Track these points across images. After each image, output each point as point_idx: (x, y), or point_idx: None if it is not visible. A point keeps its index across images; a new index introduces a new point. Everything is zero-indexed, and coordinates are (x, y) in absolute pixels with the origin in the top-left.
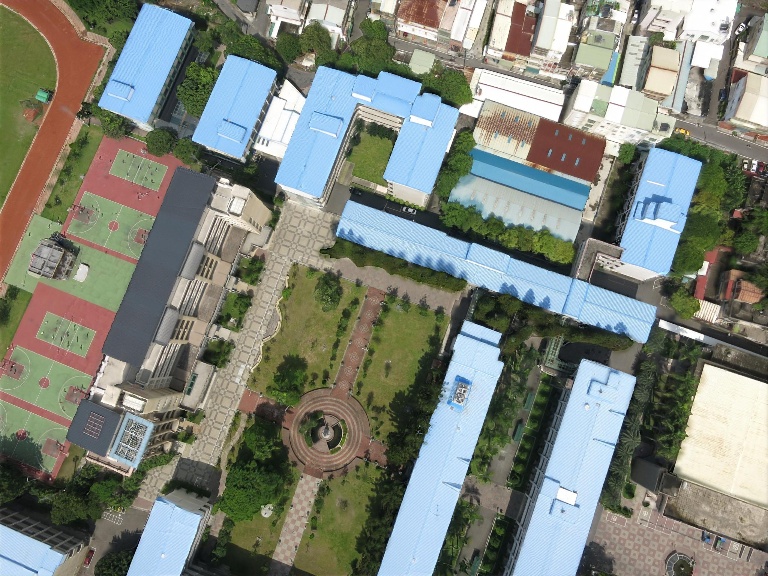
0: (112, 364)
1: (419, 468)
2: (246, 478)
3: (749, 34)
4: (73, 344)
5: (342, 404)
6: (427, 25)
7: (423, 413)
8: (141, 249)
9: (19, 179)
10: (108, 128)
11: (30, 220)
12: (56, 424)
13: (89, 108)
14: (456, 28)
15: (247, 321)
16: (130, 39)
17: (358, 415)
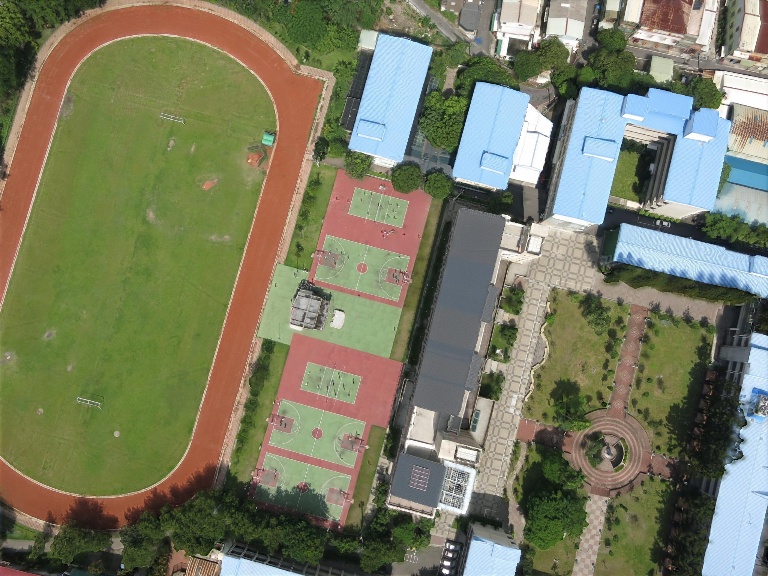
0: (420, 415)
1: (727, 481)
2: (556, 508)
3: None
4: (340, 392)
5: (619, 423)
6: (673, 32)
7: (733, 429)
8: (394, 289)
9: (255, 229)
10: (356, 169)
11: (274, 270)
12: (336, 473)
13: (324, 148)
14: (701, 32)
15: (513, 351)
16: (372, 74)
17: (636, 432)
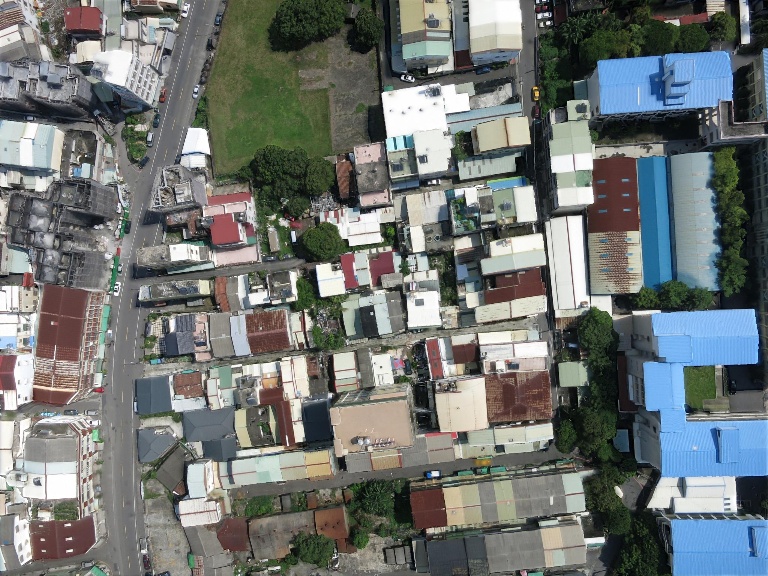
0: None
1: None
2: None
3: (416, 68)
4: None
5: None
6: (548, 384)
7: None
8: None
9: None
10: None
11: None
12: None
13: None
14: (536, 353)
15: None
16: None
17: None
